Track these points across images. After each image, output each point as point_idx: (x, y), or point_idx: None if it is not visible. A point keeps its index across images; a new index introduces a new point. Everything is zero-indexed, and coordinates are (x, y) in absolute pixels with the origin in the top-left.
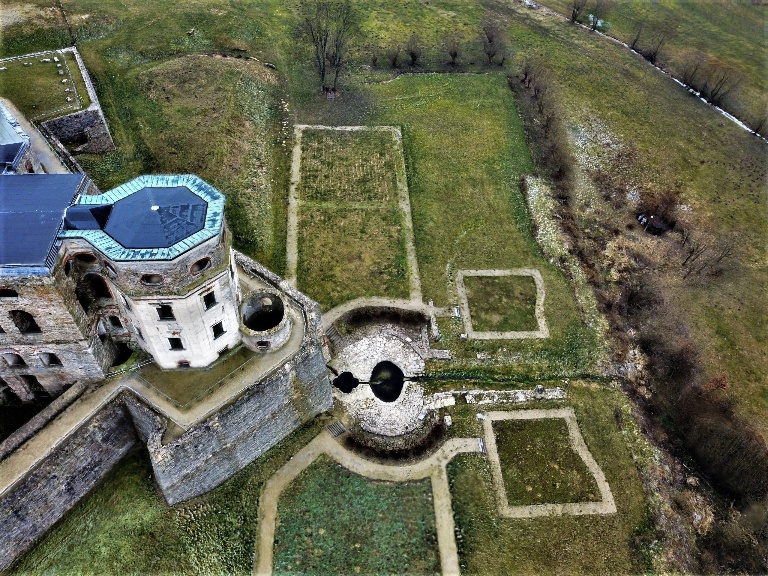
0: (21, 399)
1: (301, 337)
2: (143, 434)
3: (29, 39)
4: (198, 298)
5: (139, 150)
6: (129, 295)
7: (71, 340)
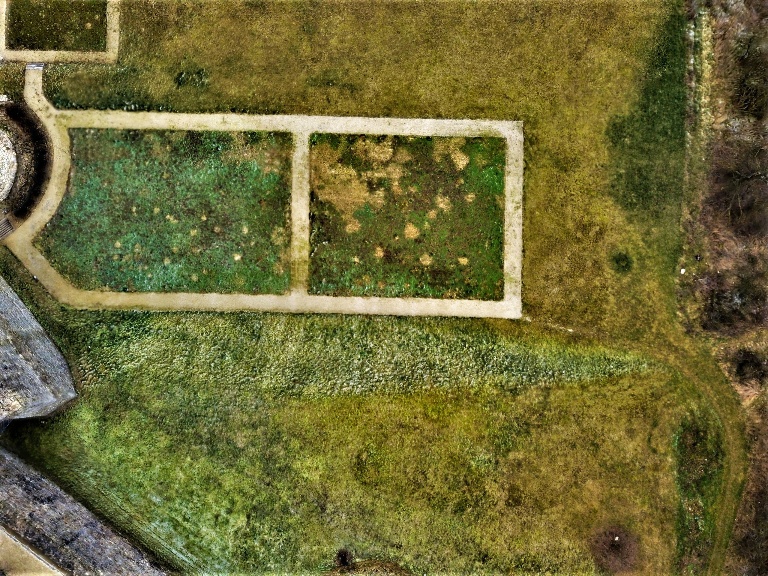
0: None
1: None
2: None
3: None
4: None
5: None
6: None
7: None
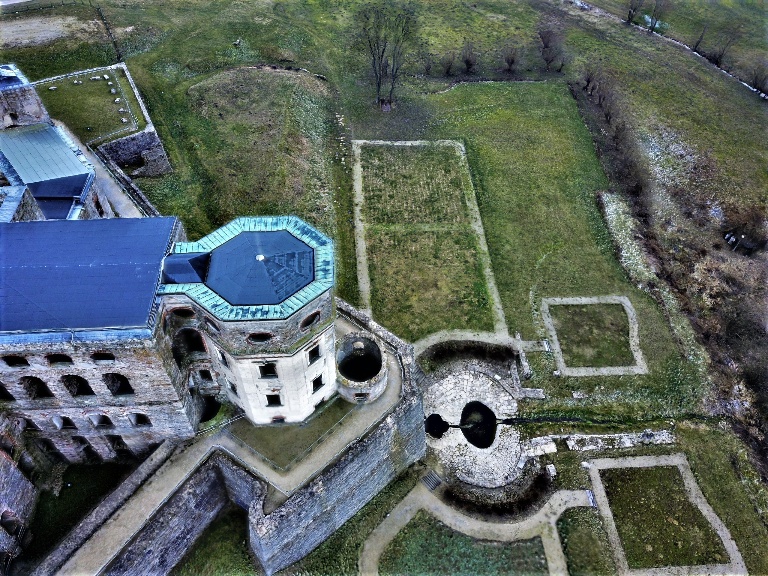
0: (102, 457)
1: (398, 385)
2: (235, 495)
3: (74, 54)
4: (303, 354)
5: (196, 172)
6: (232, 354)
7: (165, 401)
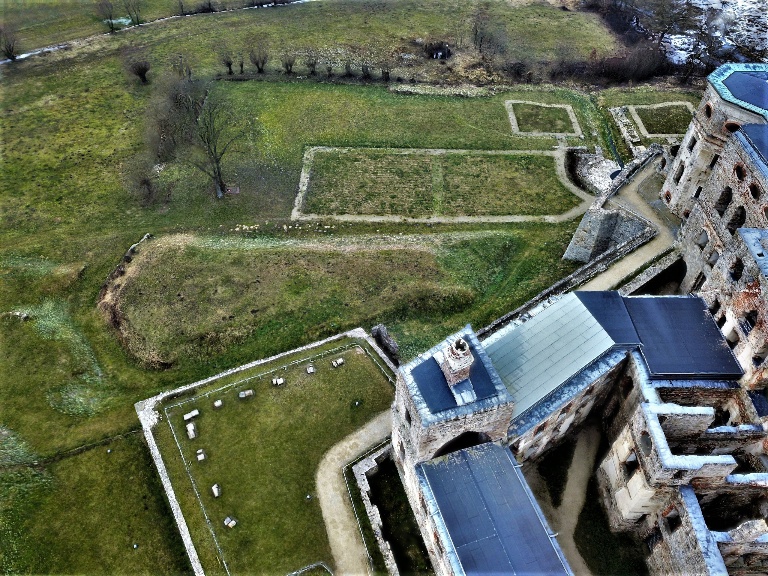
0: None
1: None
2: None
3: (3, 541)
4: None
5: None
6: None
7: None
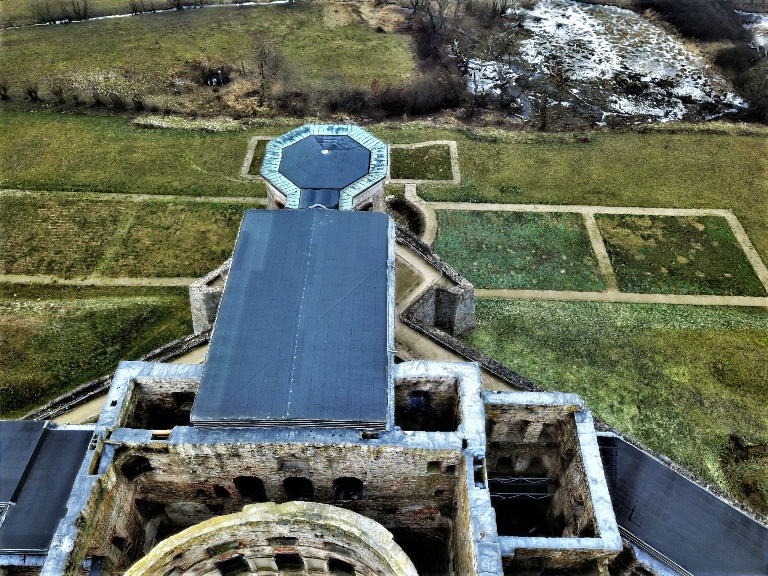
0: None
1: None
2: None
3: None
4: None
5: None
6: None
7: None
